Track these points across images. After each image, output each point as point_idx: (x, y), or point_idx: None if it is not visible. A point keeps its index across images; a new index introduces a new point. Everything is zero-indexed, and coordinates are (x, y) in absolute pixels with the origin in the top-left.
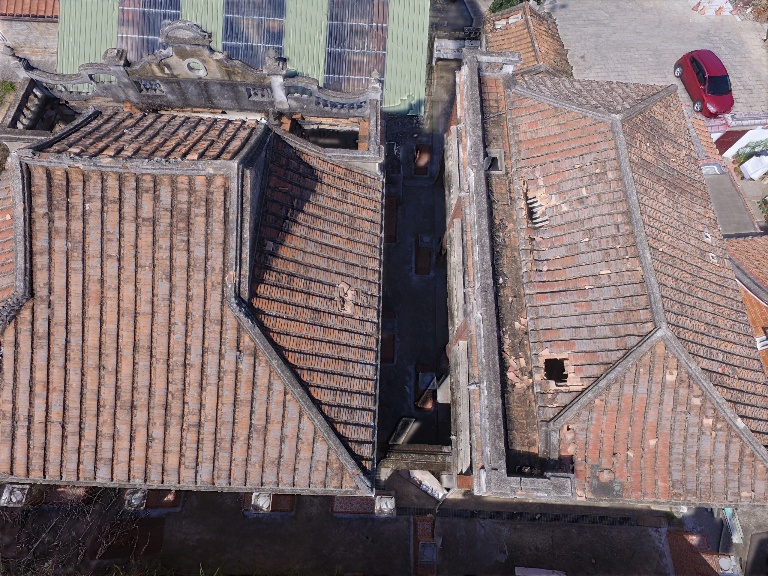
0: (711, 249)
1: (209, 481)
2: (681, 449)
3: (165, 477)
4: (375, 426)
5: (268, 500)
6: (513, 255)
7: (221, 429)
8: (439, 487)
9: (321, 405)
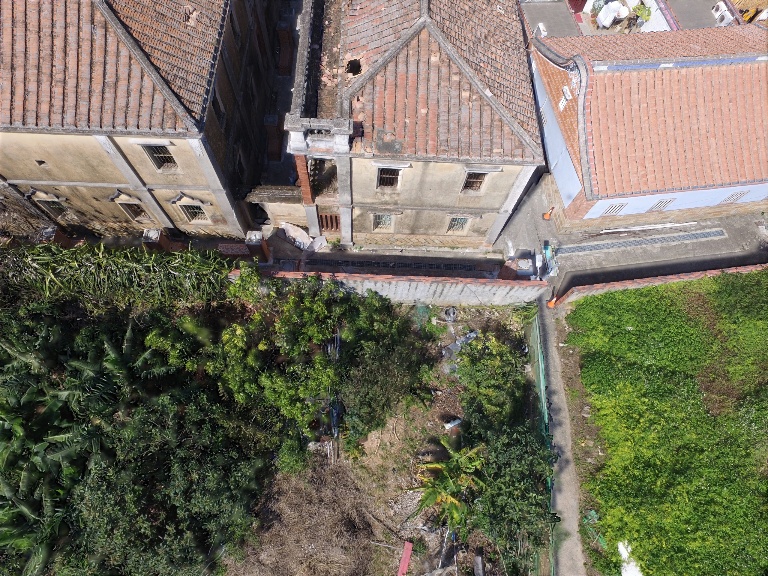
0: (501, 5)
1: (72, 123)
2: (446, 116)
3: (39, 122)
4: (208, 99)
5: (157, 233)
6: (340, 8)
7: (81, 84)
8: (308, 239)
9: (159, 70)
